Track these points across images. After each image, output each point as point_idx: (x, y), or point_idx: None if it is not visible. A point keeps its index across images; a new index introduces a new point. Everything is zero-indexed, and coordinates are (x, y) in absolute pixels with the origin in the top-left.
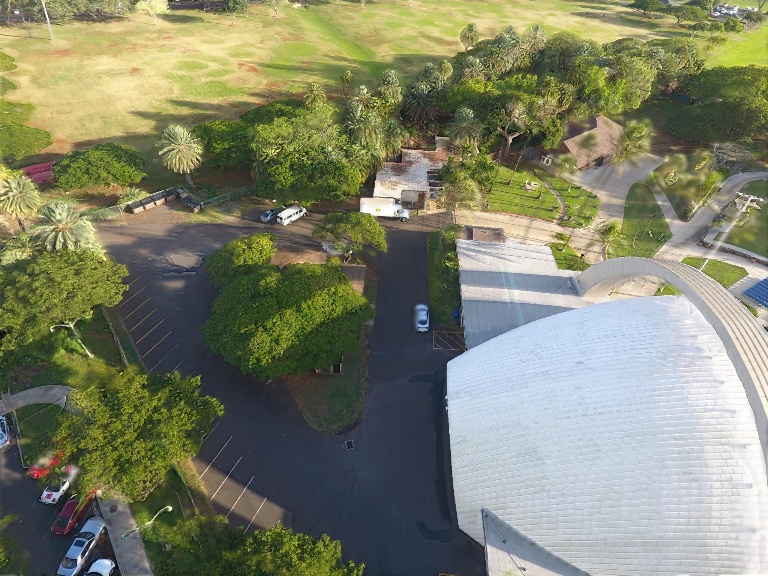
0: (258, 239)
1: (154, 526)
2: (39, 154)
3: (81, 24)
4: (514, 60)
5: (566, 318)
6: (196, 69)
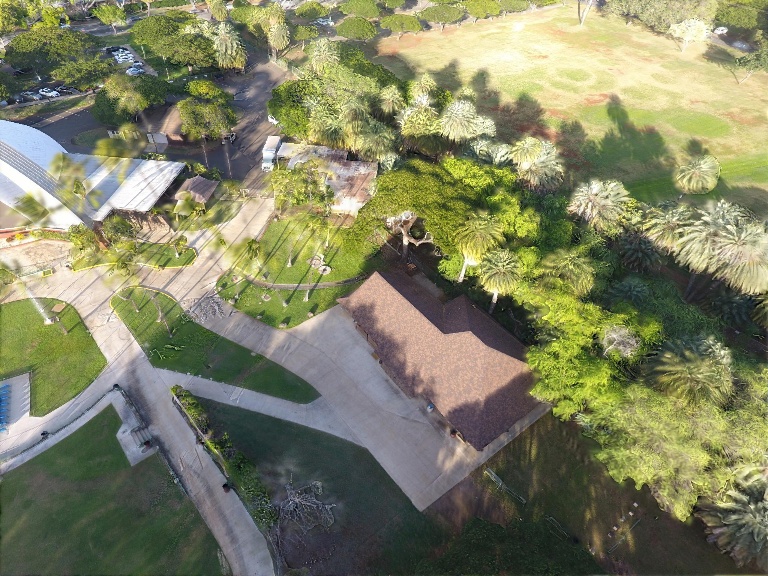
0: (205, 85)
1: (63, 101)
2: (375, 50)
3: (639, 28)
4: (718, 263)
5: (3, 136)
6: (566, 77)
